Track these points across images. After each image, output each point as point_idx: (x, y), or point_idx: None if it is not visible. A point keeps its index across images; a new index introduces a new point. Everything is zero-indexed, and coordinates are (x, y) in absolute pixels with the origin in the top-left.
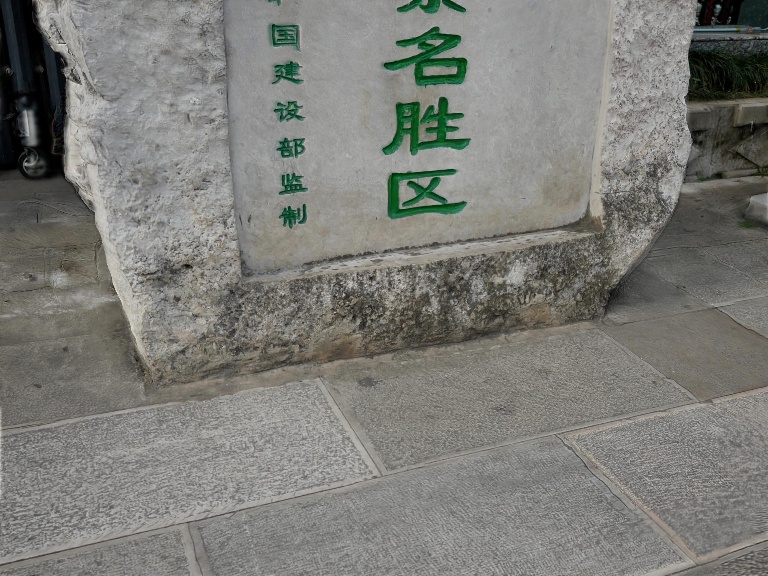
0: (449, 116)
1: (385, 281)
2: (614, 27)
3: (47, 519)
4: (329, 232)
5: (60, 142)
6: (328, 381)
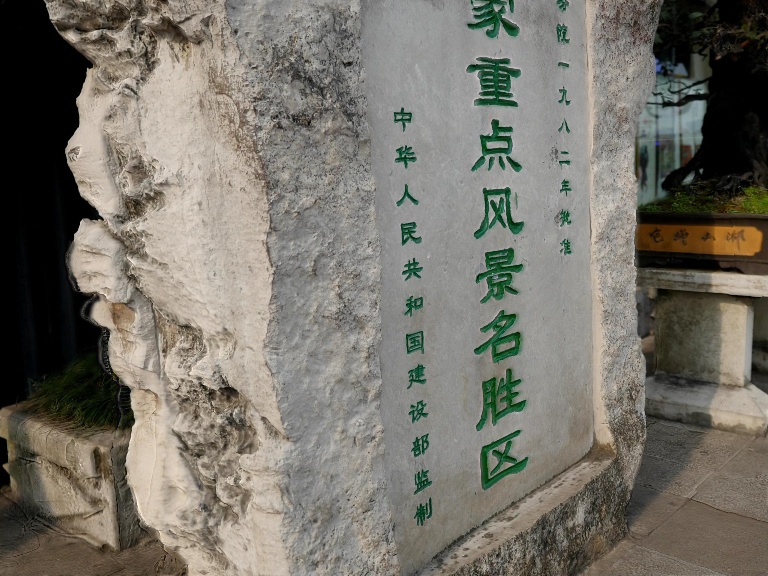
0: (512, 384)
1: (506, 555)
2: (598, 287)
3: None
4: (447, 519)
5: (125, 485)
6: None
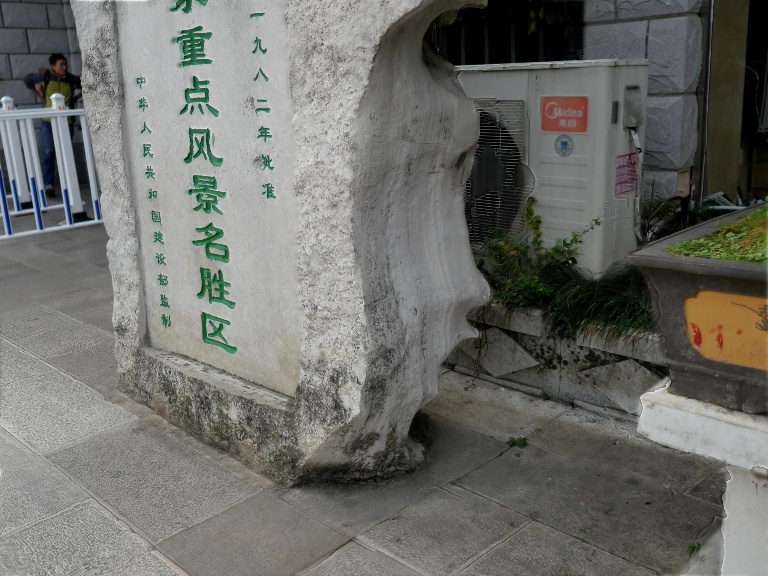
0: None
1: None
2: None
3: (3, 402)
4: (179, 337)
5: None
6: (135, 420)
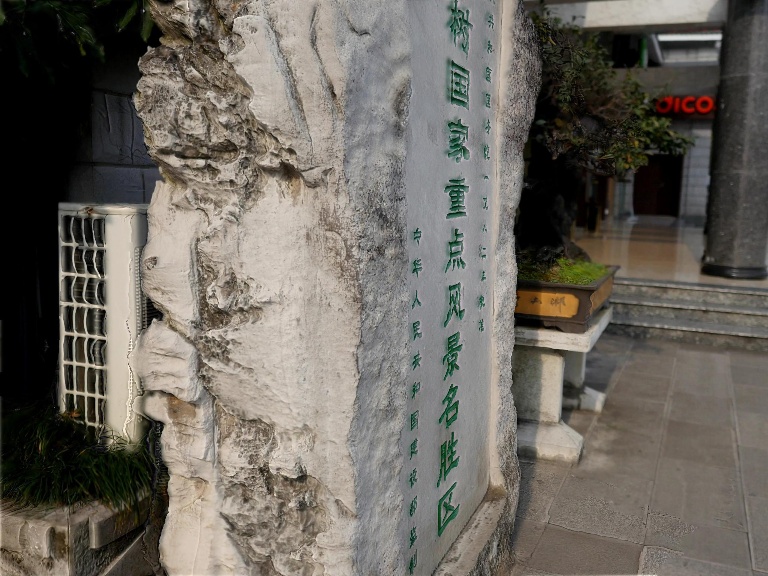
0: (453, 444)
1: None
2: (497, 356)
3: None
4: None
5: (161, 568)
6: None
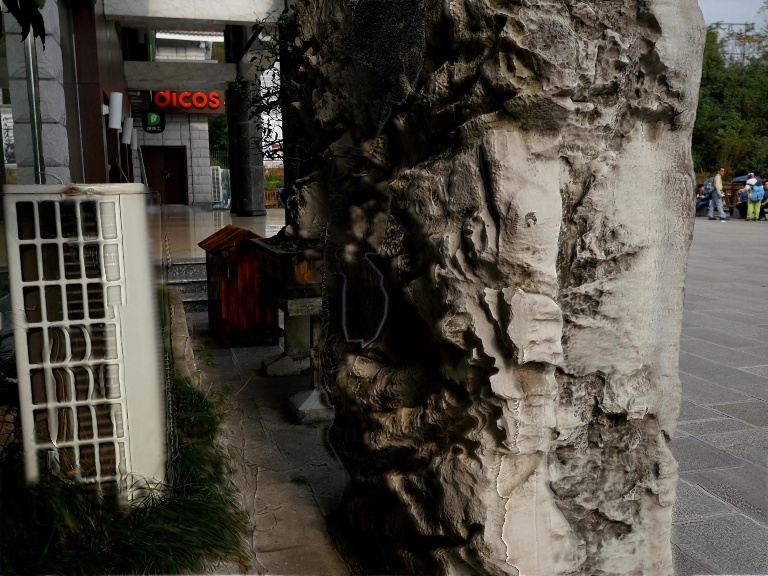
0: None
1: None
2: None
3: None
4: None
5: None
6: None
